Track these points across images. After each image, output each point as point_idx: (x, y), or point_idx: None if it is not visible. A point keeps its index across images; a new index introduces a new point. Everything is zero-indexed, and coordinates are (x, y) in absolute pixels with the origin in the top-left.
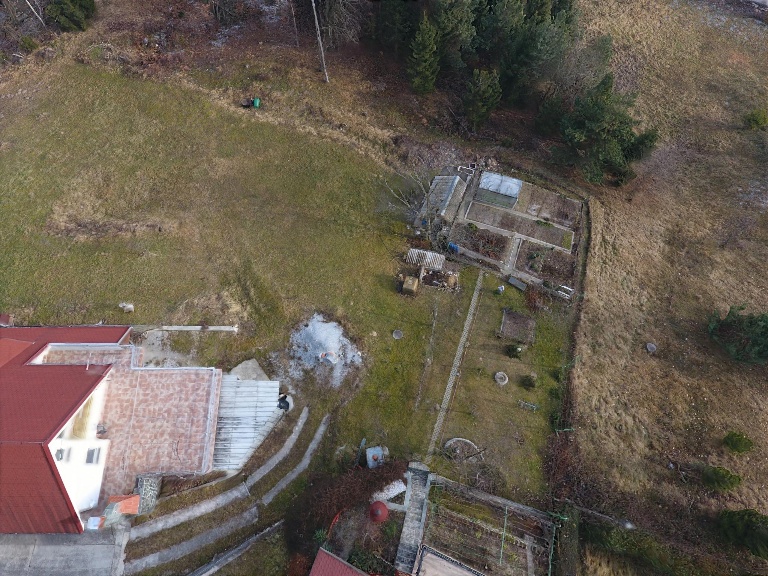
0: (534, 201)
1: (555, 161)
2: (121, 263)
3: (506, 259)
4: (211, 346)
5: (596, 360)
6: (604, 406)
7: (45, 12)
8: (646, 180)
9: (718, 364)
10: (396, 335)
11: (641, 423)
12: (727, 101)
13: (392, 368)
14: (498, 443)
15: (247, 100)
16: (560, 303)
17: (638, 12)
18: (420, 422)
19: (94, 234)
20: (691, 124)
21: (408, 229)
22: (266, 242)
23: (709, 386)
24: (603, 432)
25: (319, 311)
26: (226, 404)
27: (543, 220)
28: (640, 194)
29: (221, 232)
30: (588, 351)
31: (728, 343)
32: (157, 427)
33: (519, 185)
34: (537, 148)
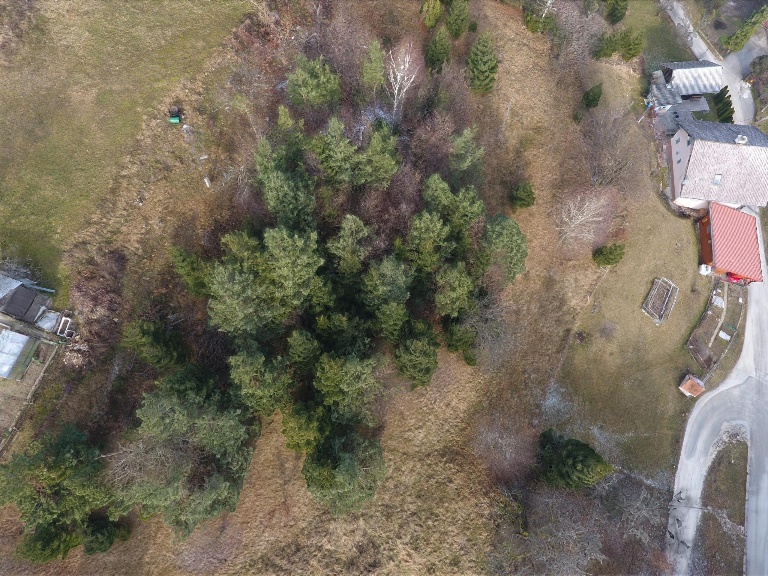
0: (5, 399)
1: None
2: None
3: None
4: None
5: None
6: None
7: None
8: (69, 568)
9: None
10: None
11: None
12: None
13: None
14: None
15: (177, 111)
16: None
17: None
18: None
19: (2, 7)
20: None
21: None
22: None
23: None
24: None
25: None
26: None
27: None
28: None
29: None
30: None
31: None
32: None
33: None
34: (123, 423)
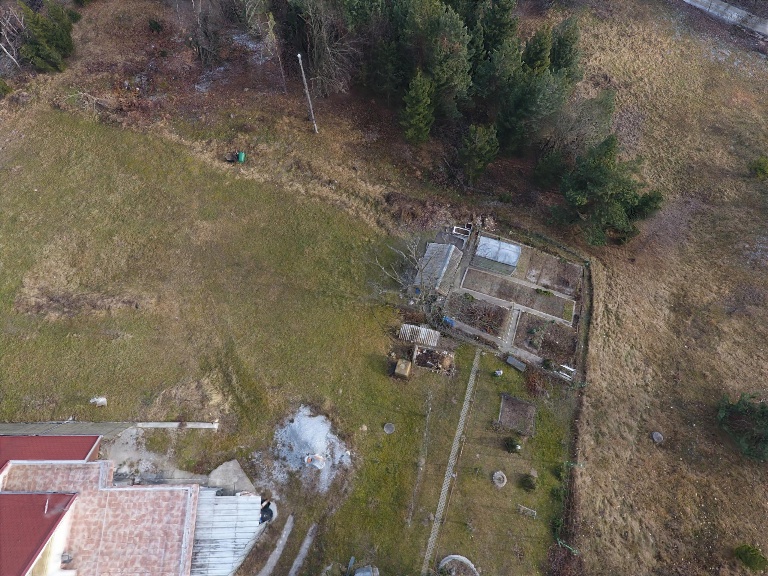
0: (533, 266)
1: (555, 220)
2: (94, 346)
3: (504, 334)
4: (189, 445)
5: (600, 453)
6: (609, 509)
7: (19, 53)
8: None
9: (728, 455)
10: (388, 429)
11: (648, 529)
12: (732, 145)
13: (383, 469)
14: (496, 559)
15: (231, 154)
16: (561, 385)
17: (639, 46)
18: (413, 536)
19: (66, 312)
20: (695, 171)
21: (401, 298)
22: (250, 319)
23: (719, 483)
24: (608, 540)
25: (305, 402)
26: (203, 524)
27: (543, 288)
28: (643, 253)
29: (202, 307)
30: (591, 442)
31: (739, 433)
32: (128, 554)
33: (518, 253)
34: (536, 202)
